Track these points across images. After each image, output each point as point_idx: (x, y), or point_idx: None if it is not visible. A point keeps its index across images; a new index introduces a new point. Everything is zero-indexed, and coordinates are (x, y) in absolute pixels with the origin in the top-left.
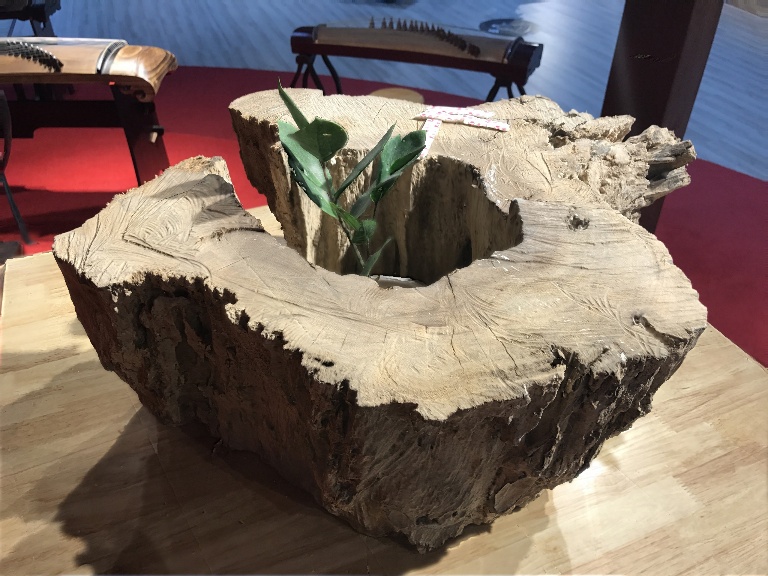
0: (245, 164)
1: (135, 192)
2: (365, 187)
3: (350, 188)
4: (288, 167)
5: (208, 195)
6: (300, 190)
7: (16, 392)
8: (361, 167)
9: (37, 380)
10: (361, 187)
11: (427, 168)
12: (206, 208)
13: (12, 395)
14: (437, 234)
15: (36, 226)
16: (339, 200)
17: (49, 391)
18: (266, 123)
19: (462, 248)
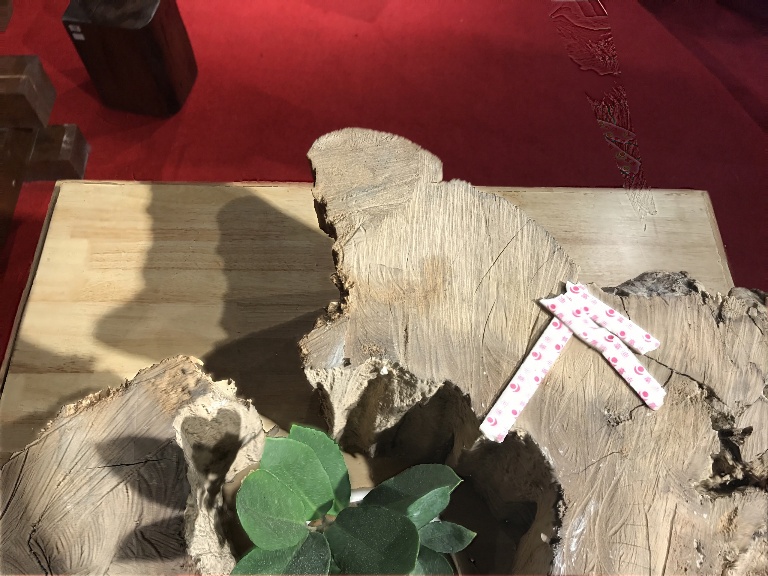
0: (318, 216)
1: (83, 419)
2: (422, 399)
3: (401, 397)
4: (313, 380)
5: (153, 498)
6: (329, 391)
7: (21, 406)
8: (358, 557)
9: (44, 396)
10: (416, 401)
11: (507, 435)
12: (140, 529)
13: (17, 408)
14: (502, 469)
15: (110, 125)
16: (384, 398)
17: (51, 418)
18: (334, 229)
19: (526, 500)
